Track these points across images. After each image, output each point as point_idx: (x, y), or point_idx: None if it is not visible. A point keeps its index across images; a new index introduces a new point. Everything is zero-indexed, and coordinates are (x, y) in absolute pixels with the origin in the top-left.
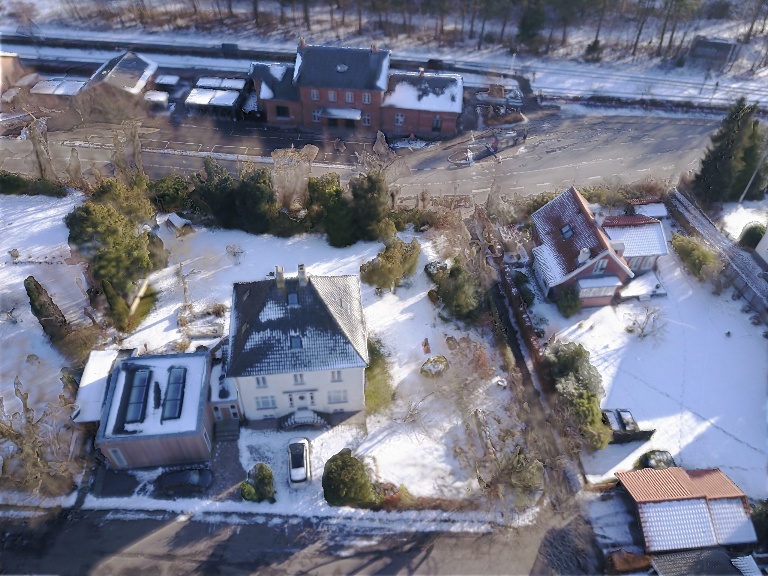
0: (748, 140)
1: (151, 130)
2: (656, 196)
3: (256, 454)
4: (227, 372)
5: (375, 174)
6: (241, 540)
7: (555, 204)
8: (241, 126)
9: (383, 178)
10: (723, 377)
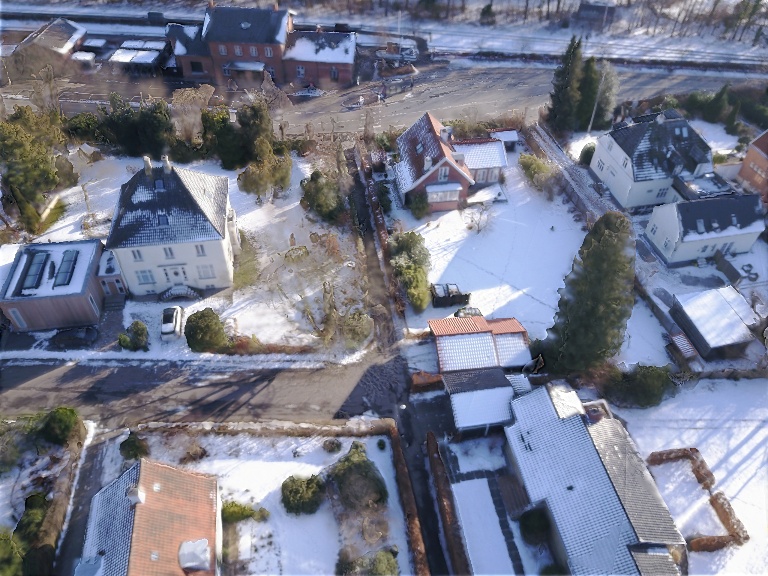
0: (580, 72)
1: (77, 85)
2: (517, 129)
3: (137, 319)
4: (106, 245)
5: (258, 105)
6: (117, 377)
7: (414, 128)
8: (160, 81)
9: (264, 108)
10: (541, 260)
